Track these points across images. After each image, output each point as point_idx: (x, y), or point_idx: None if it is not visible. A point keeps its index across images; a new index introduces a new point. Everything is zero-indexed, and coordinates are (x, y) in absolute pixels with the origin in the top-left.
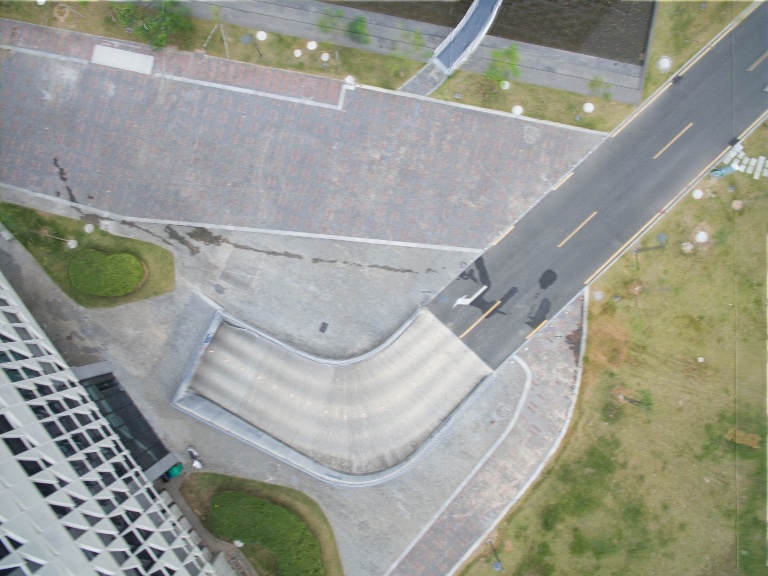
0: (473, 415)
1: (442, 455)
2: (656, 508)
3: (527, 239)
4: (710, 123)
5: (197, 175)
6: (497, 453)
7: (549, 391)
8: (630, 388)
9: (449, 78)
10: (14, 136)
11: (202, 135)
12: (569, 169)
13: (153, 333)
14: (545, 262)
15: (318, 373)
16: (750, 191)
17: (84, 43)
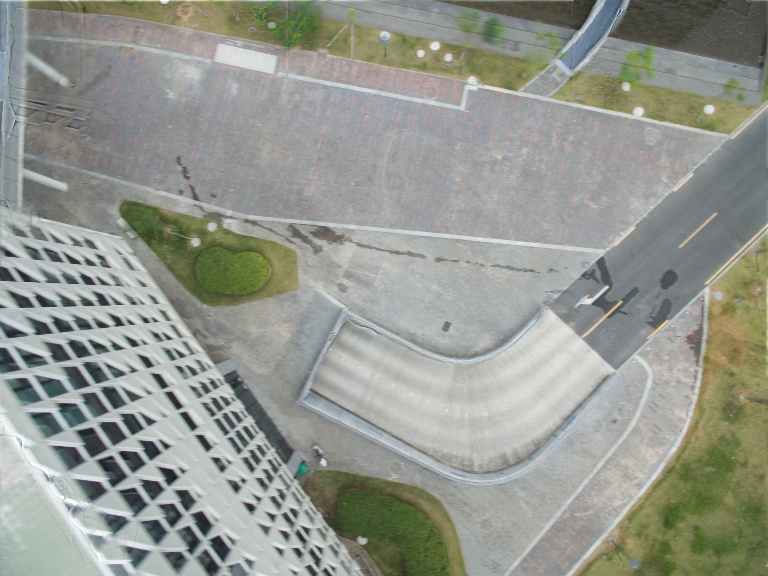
0: (595, 414)
1: (564, 454)
2: None
3: (648, 240)
4: None
5: (320, 174)
6: (618, 452)
7: (670, 391)
8: (750, 388)
9: (571, 79)
10: (137, 134)
11: (325, 134)
12: (689, 170)
13: (276, 331)
14: (666, 263)
15: (438, 372)
16: None
17: (207, 42)
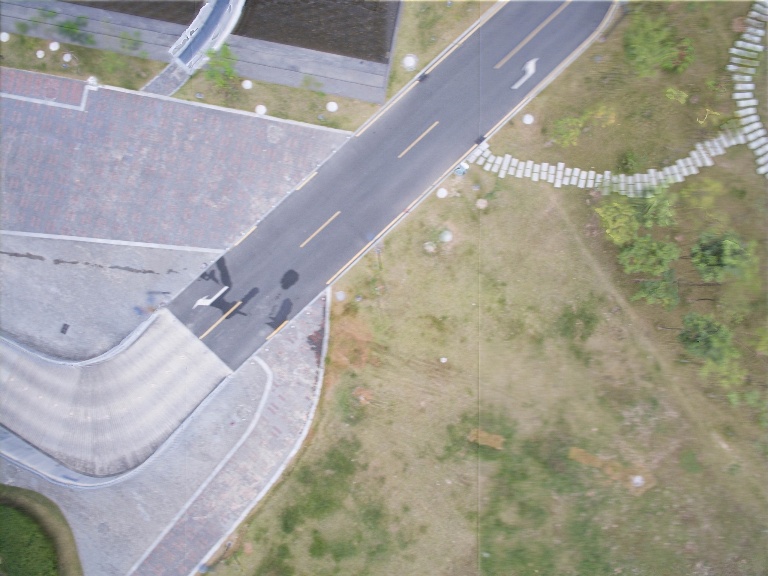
0: (213, 416)
1: (182, 457)
2: (396, 510)
3: (269, 239)
4: (456, 121)
5: None
6: (237, 455)
7: (290, 392)
8: (372, 389)
9: (192, 78)
10: None
11: None
12: (313, 169)
13: None
14: (287, 262)
15: (66, 375)
16: (495, 190)
17: None
